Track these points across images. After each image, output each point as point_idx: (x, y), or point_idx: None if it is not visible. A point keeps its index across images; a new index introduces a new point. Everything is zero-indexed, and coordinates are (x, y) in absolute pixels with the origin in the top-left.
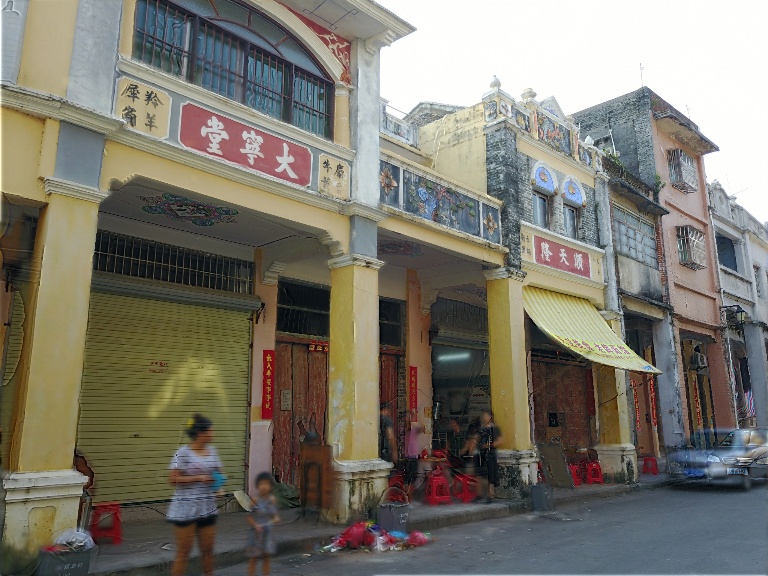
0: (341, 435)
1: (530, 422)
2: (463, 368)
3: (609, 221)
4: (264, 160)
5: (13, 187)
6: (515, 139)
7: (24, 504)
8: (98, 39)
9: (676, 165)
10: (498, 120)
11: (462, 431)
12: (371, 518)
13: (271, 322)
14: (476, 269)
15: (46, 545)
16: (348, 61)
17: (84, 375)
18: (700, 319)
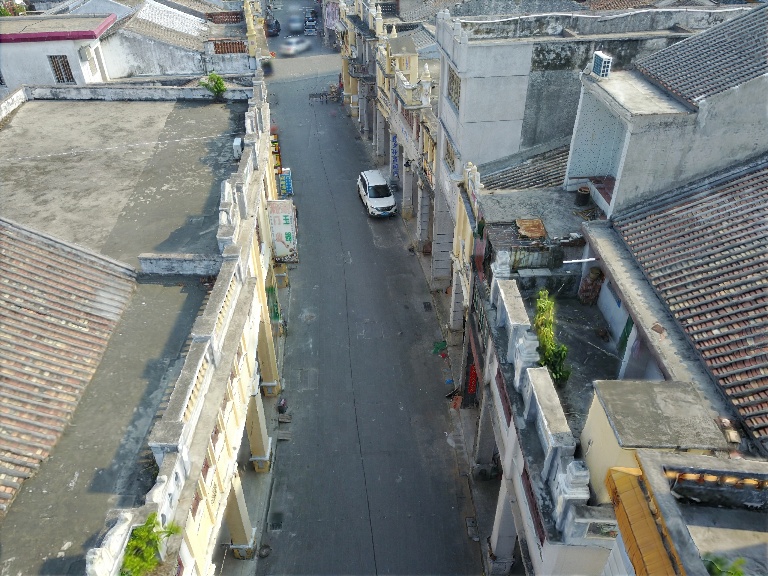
0: None
1: None
2: None
3: None
4: None
5: None
6: None
7: None
8: None
9: None
10: None
11: None
12: None
13: None
14: None
15: None
16: None
17: None
18: None
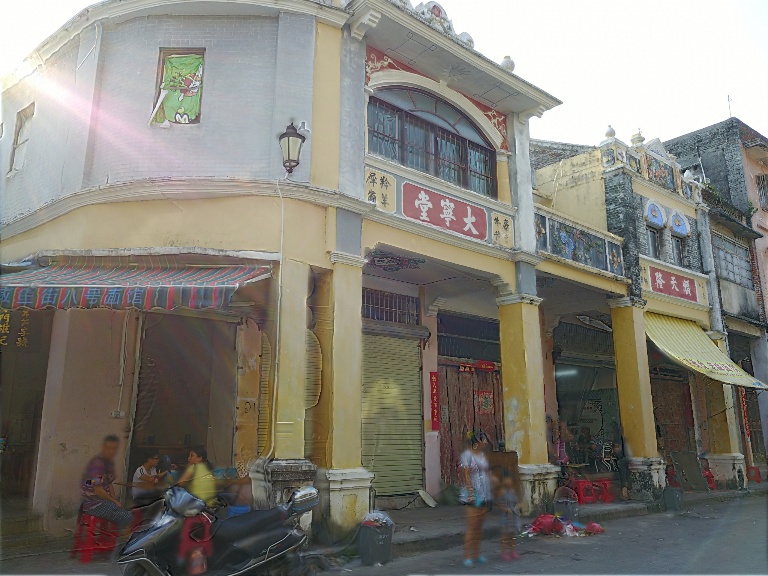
0: (518, 443)
1: (656, 433)
2: (578, 384)
3: (711, 248)
4: (456, 222)
5: (313, 260)
6: (631, 182)
7: (339, 492)
8: (353, 142)
9: (766, 190)
10: (616, 166)
11: (573, 441)
12: (549, 512)
13: (434, 348)
14: (599, 298)
15: (353, 522)
16: (505, 131)
17: (314, 395)
18: None
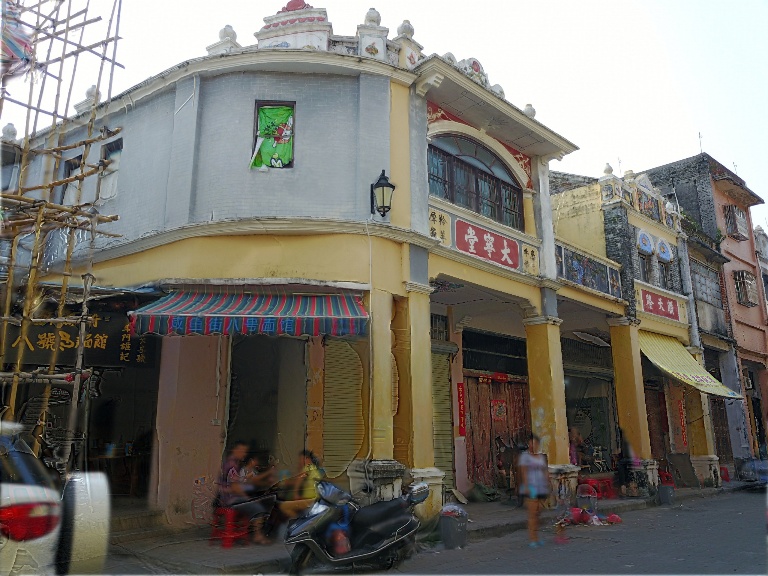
0: (545, 447)
1: None
2: (573, 393)
3: (689, 272)
4: (496, 253)
5: (393, 289)
6: (626, 214)
7: None
8: (420, 186)
9: (731, 219)
10: (615, 201)
11: None
12: (573, 506)
13: (460, 362)
14: (599, 317)
15: (431, 513)
16: (530, 172)
17: None
18: (754, 349)
